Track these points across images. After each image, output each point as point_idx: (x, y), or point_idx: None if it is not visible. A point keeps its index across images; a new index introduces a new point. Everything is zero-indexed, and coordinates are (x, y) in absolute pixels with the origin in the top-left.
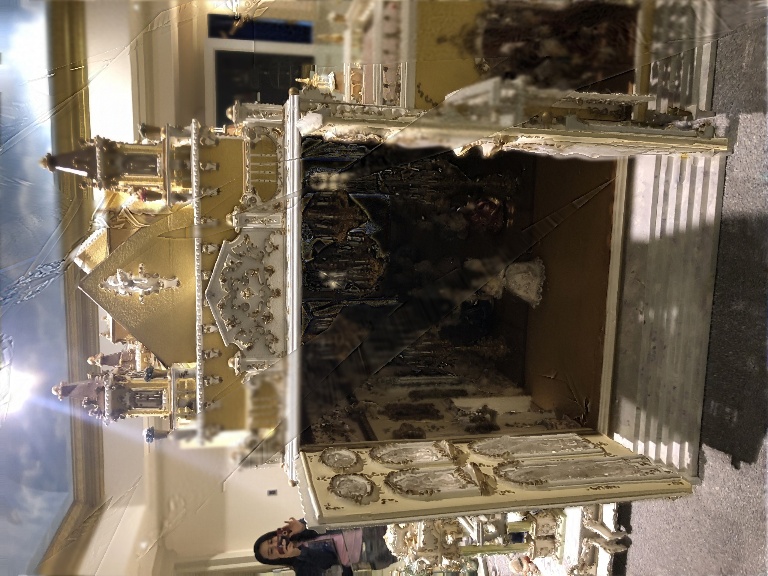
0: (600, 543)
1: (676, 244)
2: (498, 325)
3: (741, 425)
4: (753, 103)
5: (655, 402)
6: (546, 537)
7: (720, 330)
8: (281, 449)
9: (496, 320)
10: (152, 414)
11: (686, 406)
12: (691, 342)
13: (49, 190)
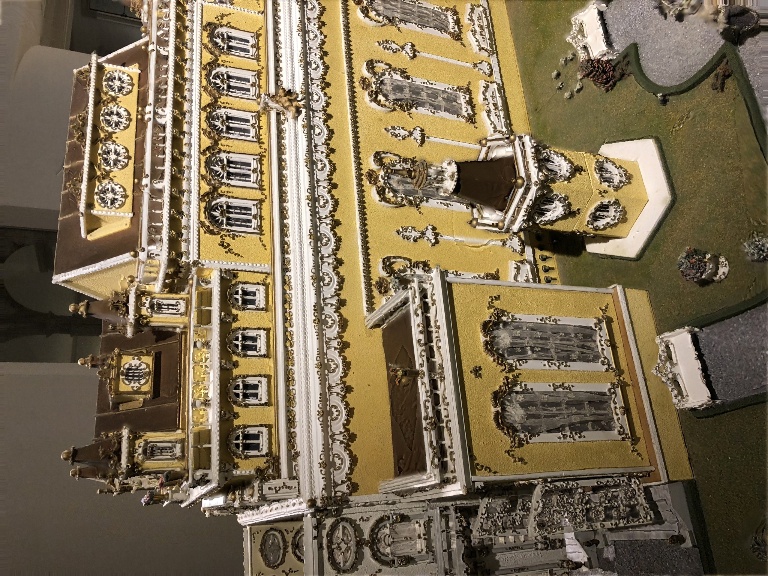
0: None
1: None
2: None
3: None
4: None
5: None
6: None
7: None
8: None
9: None
10: None
11: None
12: None
13: None
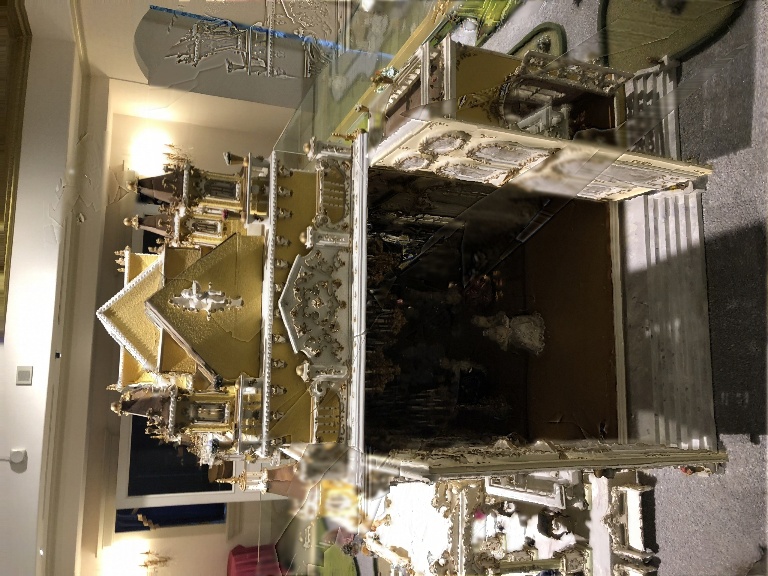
0: (631, 566)
1: (670, 267)
2: (495, 388)
3: (754, 403)
4: (717, 150)
5: (671, 406)
6: (574, 575)
7: (719, 330)
8: None
9: (492, 384)
10: (213, 429)
11: (699, 403)
12: (695, 346)
13: (422, 1)
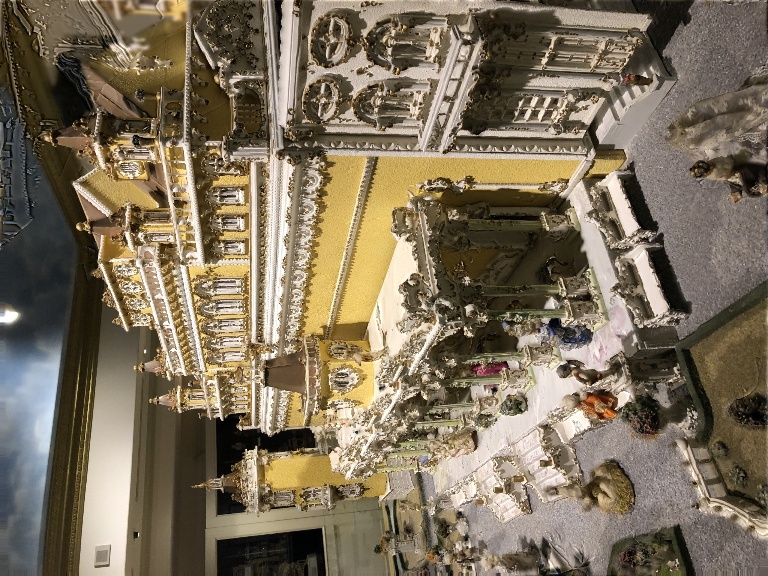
0: None
1: None
2: None
3: None
4: None
5: None
6: None
7: None
8: (266, 139)
9: None
10: None
11: None
12: (616, 4)
13: None
